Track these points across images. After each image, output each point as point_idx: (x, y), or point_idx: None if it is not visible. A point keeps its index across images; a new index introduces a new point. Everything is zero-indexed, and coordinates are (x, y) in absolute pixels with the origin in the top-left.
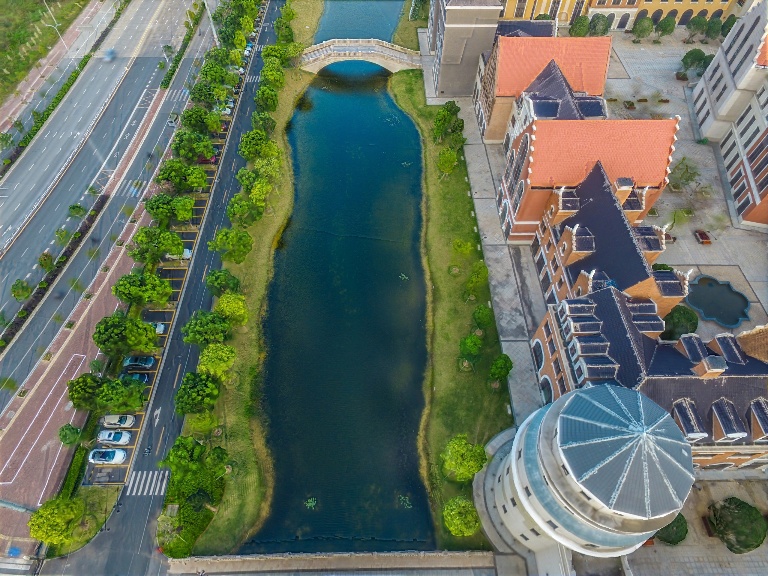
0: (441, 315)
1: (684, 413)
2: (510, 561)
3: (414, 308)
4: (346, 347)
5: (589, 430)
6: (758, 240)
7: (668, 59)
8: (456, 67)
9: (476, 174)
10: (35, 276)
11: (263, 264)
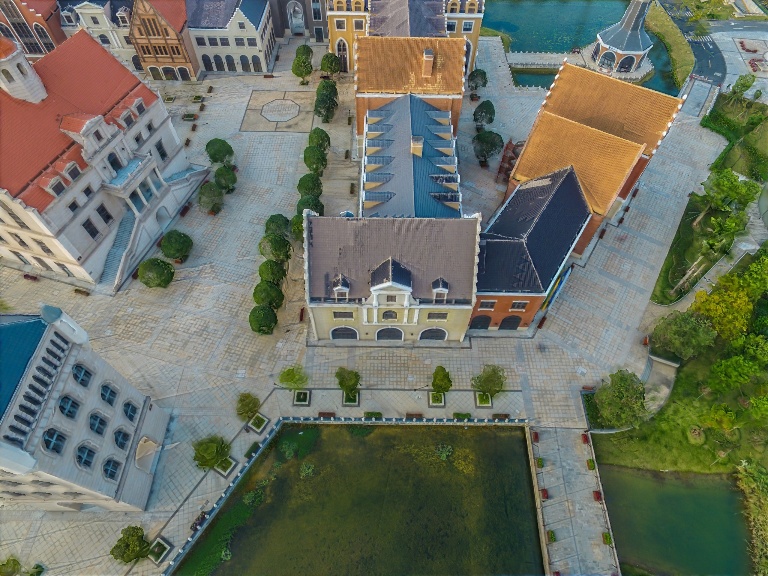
0: None
1: None
2: None
3: None
4: None
5: None
6: None
7: (272, 171)
8: None
9: None
10: None
11: None
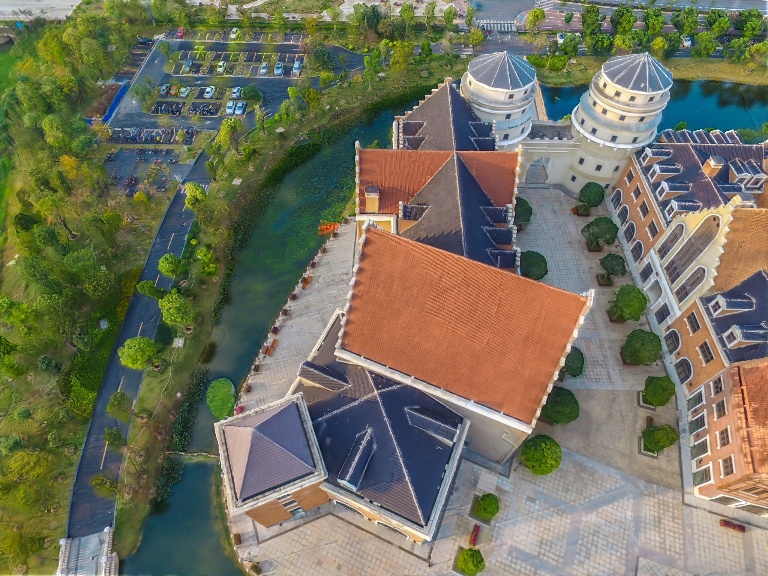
0: None
1: None
2: None
3: None
4: None
5: None
6: None
7: None
8: None
9: None
10: (644, 5)
11: (698, 75)
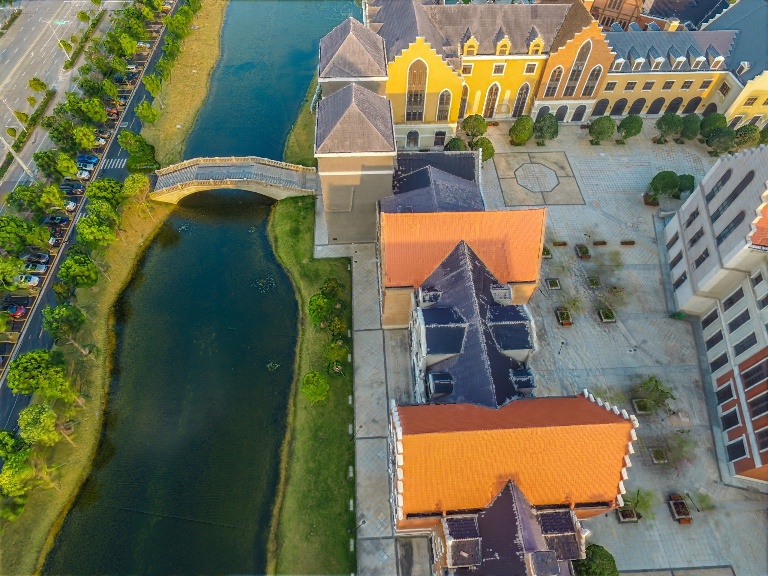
0: None
1: None
2: None
3: None
4: None
5: None
6: (758, 509)
7: (634, 170)
8: (347, 214)
9: (365, 389)
10: None
11: None
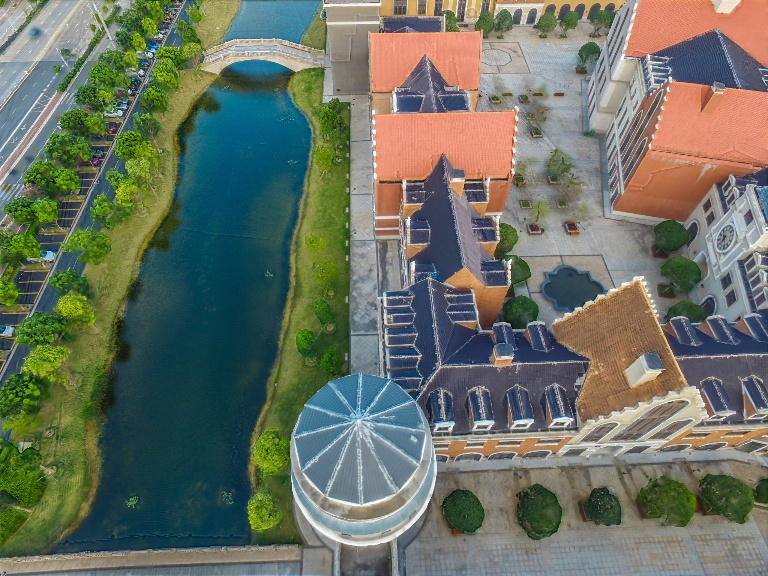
0: (298, 311)
1: (475, 401)
2: (317, 554)
3: (273, 305)
4: (198, 345)
5: (320, 419)
6: (626, 230)
7: (571, 53)
8: (347, 65)
9: (358, 170)
10: None
11: (128, 265)
